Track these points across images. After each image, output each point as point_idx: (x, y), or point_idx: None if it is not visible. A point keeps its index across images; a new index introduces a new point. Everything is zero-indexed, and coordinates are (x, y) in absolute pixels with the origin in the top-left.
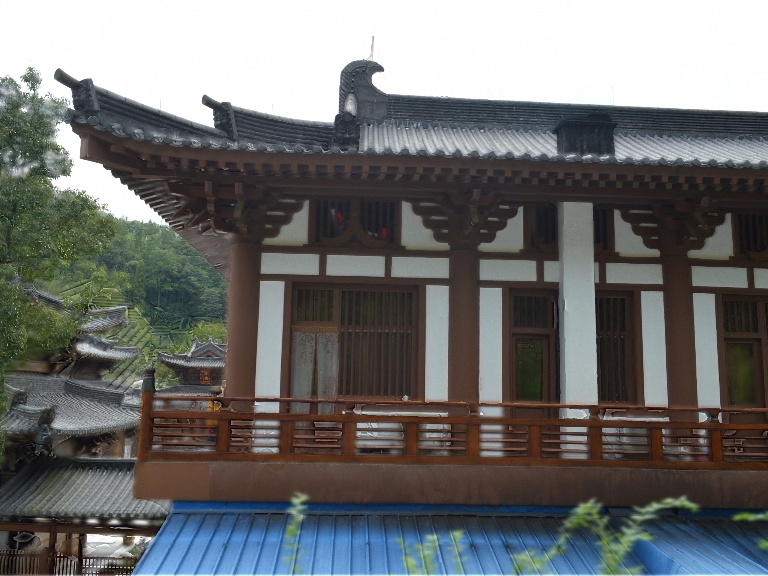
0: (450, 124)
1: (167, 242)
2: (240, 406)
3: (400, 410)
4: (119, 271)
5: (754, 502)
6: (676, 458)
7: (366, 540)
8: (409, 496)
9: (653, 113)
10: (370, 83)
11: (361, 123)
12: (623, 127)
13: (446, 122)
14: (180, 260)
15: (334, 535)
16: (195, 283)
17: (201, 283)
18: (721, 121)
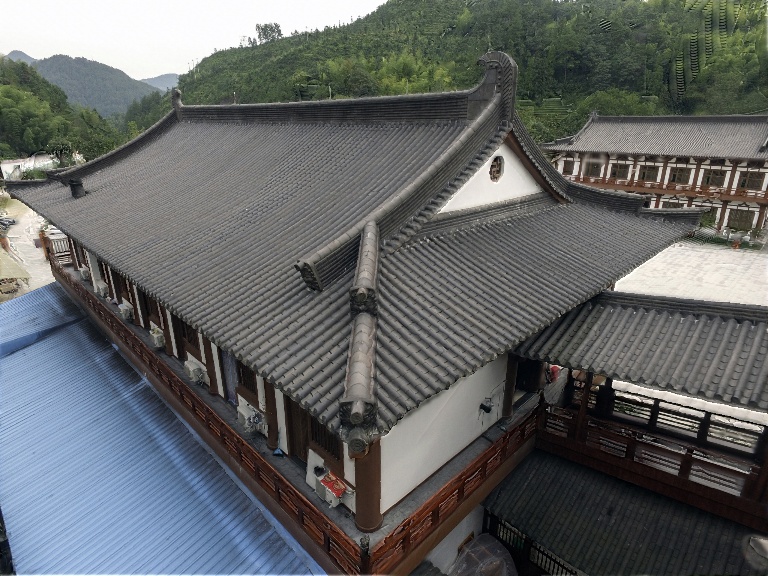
0: (195, 121)
1: (581, 24)
2: (72, 257)
3: (86, 266)
4: (535, 57)
5: (93, 319)
6: (85, 301)
7: (49, 300)
8: (68, 292)
9: (243, 110)
10: (177, 102)
11: (178, 122)
12: (236, 119)
13: (194, 120)
14: (585, 40)
15: (51, 297)
16: (593, 58)
17: (598, 57)
18: (265, 113)
